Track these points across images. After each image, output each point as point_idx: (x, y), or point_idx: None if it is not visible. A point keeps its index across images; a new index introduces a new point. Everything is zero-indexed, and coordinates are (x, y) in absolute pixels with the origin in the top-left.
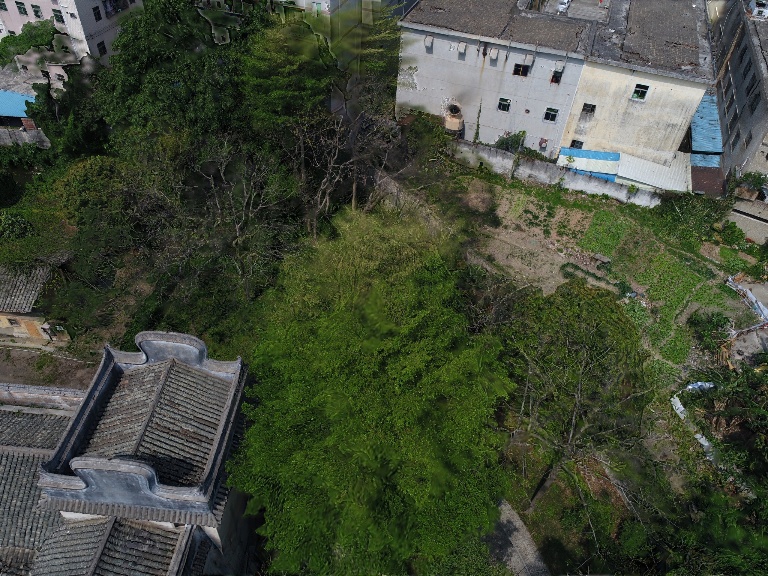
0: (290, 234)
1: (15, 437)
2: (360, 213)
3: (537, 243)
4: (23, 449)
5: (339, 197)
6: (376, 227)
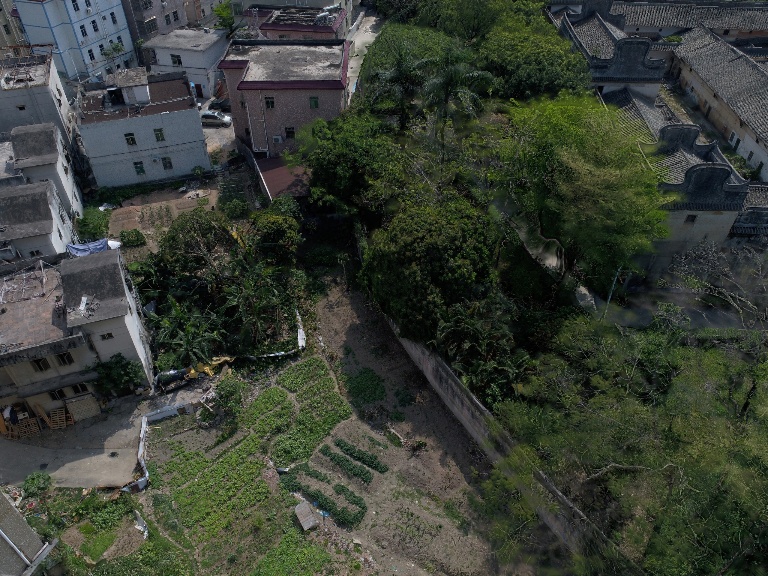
0: (766, 520)
1: (765, 196)
2: (690, 574)
3: (390, 568)
4: (750, 185)
5: (739, 573)
6: (639, 407)
